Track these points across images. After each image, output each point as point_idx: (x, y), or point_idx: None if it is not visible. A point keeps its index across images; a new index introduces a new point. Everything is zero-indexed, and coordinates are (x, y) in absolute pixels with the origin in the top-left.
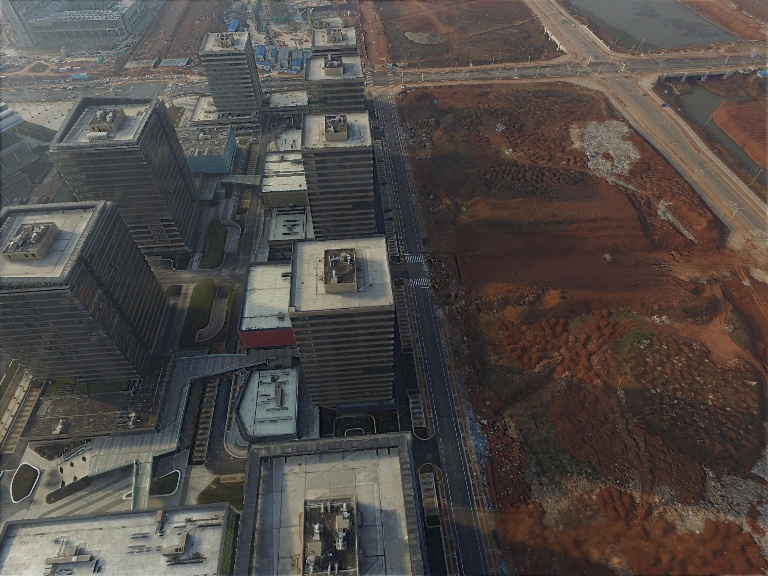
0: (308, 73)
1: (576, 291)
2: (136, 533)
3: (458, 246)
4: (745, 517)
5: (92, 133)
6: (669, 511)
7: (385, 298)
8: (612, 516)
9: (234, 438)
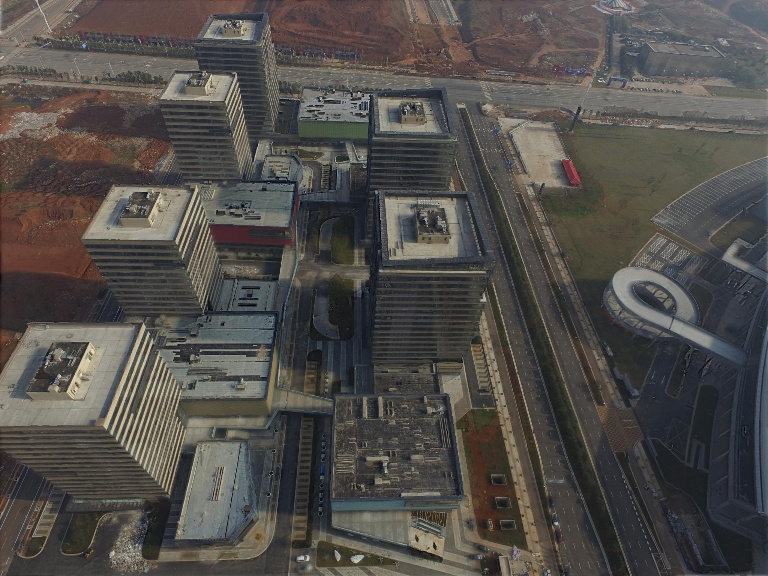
0: (126, 360)
1: (6, 215)
2: (339, 118)
3: (71, 281)
4: (50, 127)
5: (435, 203)
6: (84, 133)
7: (179, 76)
8: (115, 134)
9: (307, 172)
